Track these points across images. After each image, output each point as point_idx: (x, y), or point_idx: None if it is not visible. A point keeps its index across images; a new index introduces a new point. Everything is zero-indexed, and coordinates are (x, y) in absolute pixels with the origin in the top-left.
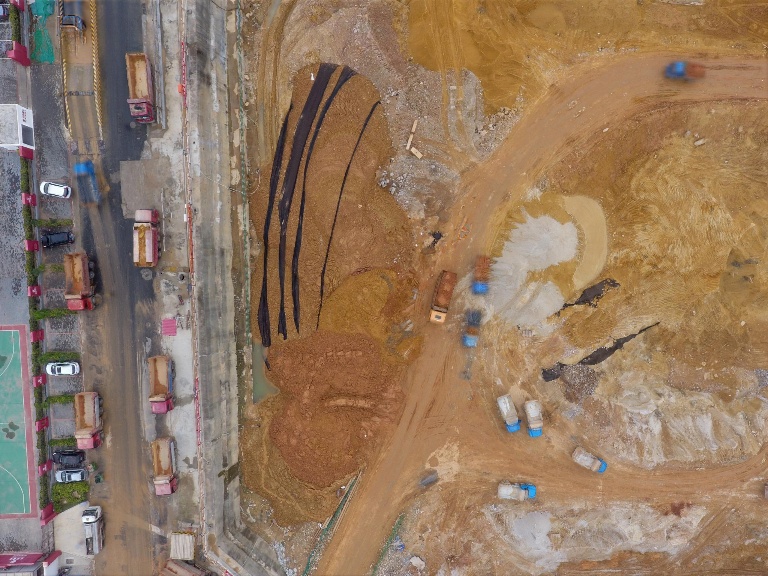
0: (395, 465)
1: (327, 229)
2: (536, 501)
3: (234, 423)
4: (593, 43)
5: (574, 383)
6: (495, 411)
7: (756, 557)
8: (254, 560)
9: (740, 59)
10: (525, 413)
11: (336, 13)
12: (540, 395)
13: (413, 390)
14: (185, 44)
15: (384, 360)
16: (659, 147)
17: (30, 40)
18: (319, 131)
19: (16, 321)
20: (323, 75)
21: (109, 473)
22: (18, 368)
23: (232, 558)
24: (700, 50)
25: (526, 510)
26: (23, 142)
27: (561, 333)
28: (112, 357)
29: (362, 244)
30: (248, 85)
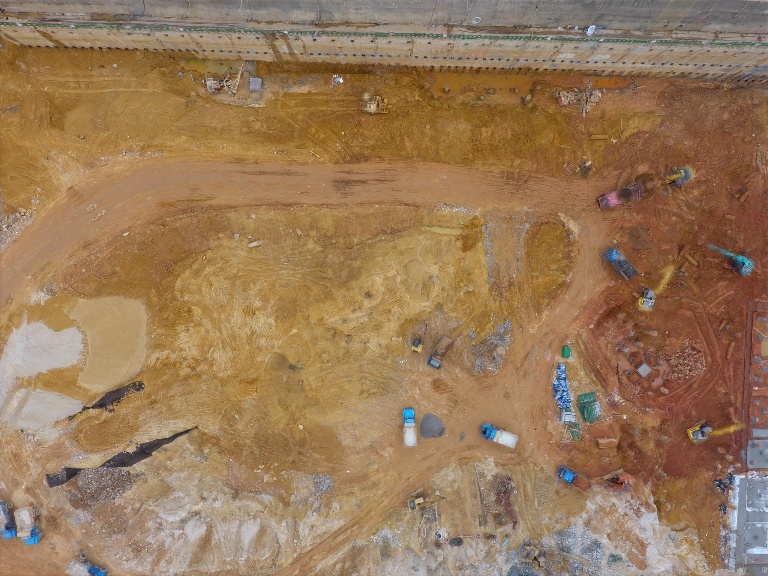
0: None
1: None
2: None
3: None
4: (118, 147)
5: (87, 488)
6: None
7: None
8: None
9: (283, 165)
10: None
11: None
12: (45, 500)
13: None
14: None
15: None
16: (207, 248)
17: None
18: None
19: None
20: None
21: None
22: None
23: None
24: (237, 155)
25: None
26: None
27: (68, 438)
28: None
29: None
30: None
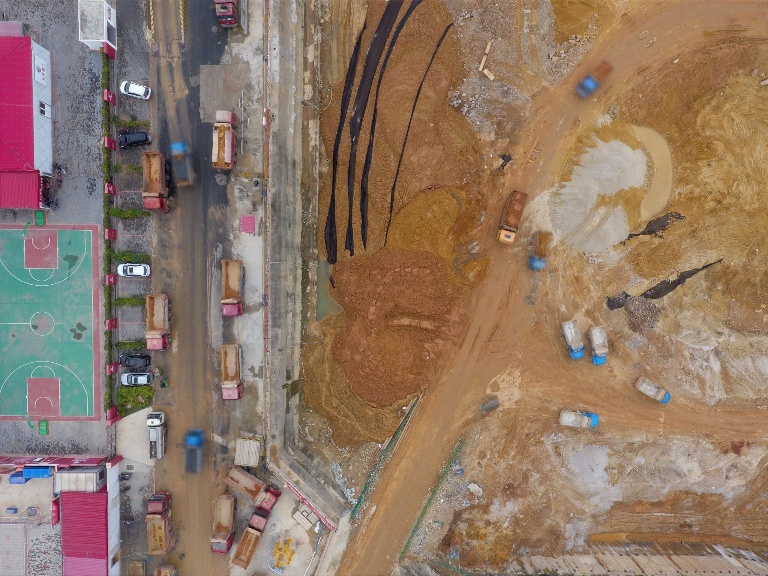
0: (456, 388)
1: (398, 146)
2: (597, 431)
3: (297, 339)
4: None
5: (638, 314)
6: (558, 338)
7: None
8: (313, 477)
9: None
10: (589, 340)
11: None
12: (604, 323)
13: (477, 313)
14: None
15: (450, 280)
16: (725, 85)
17: None
18: (392, 50)
19: (89, 221)
20: None
21: (174, 379)
22: (89, 268)
23: (293, 471)
24: None
25: (585, 441)
26: (108, 39)
27: (627, 261)
28: (182, 262)
29: (433, 161)
30: (324, 2)
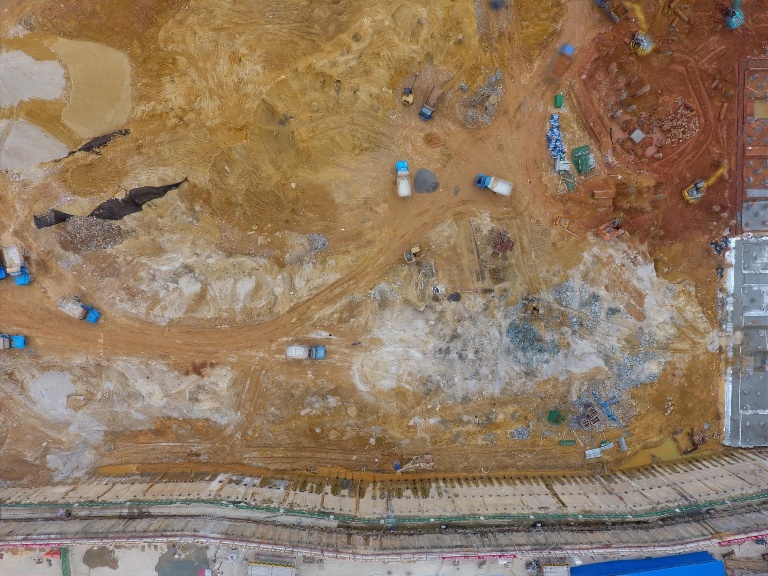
0: None
1: None
2: (32, 354)
3: None
4: None
5: (77, 233)
6: None
7: (315, 428)
8: None
9: None
10: None
11: None
12: (34, 243)
13: None
14: None
15: None
16: None
17: None
18: None
19: None
20: None
21: None
22: None
23: None
24: None
25: (30, 366)
26: None
27: (55, 179)
28: None
29: None
30: None
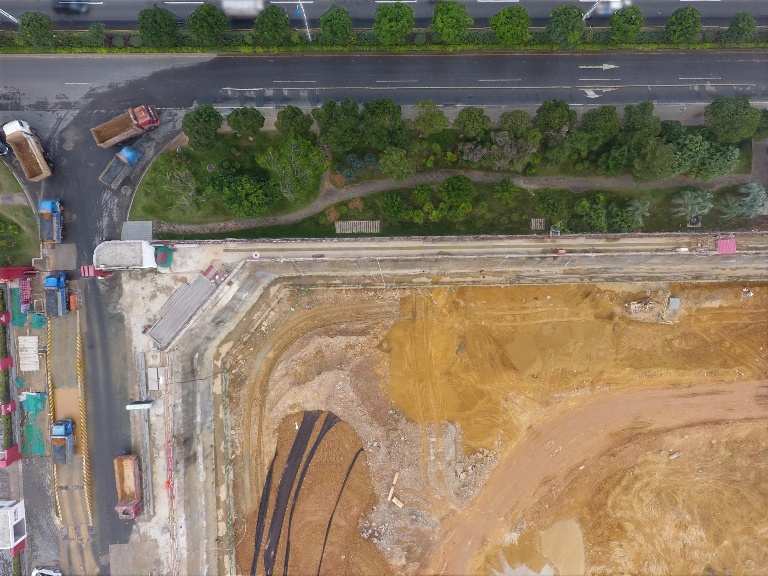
0: None
1: None
2: None
3: None
4: (569, 383)
5: None
6: None
7: None
8: None
9: (712, 385)
10: None
11: (319, 376)
12: None
13: None
14: (172, 437)
15: None
16: (635, 465)
17: (22, 434)
18: (303, 481)
19: None
20: (307, 424)
21: None
22: None
23: None
24: (673, 381)
25: None
26: (15, 541)
27: None
28: None
29: None
30: (234, 438)
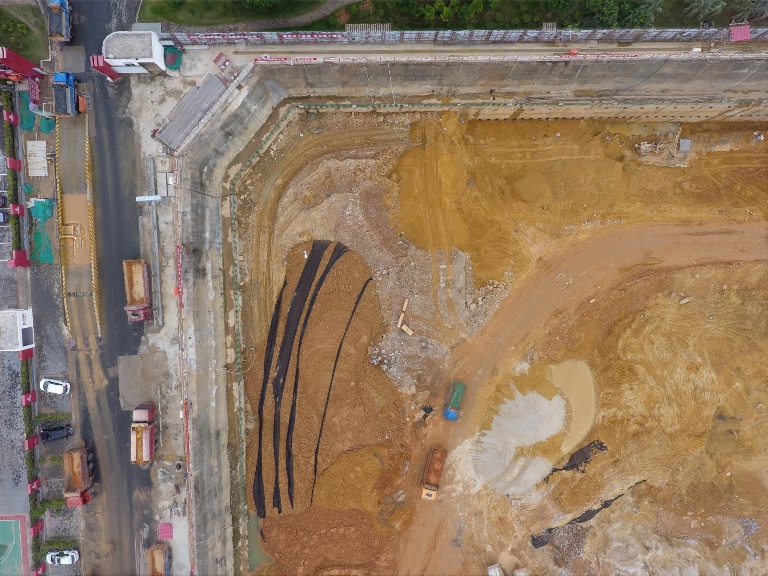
0: None
1: (320, 406)
2: None
3: None
4: (580, 216)
5: (563, 546)
6: None
7: None
8: None
9: (723, 224)
10: None
11: (328, 199)
12: (529, 561)
13: (405, 558)
14: (181, 245)
15: (377, 532)
16: (645, 308)
17: (30, 241)
18: (312, 309)
19: (17, 511)
20: (316, 253)
21: None
22: (19, 556)
23: None
24: (684, 218)
25: None
26: (23, 345)
27: (550, 500)
28: (110, 543)
29: (354, 423)
30: (243, 265)
